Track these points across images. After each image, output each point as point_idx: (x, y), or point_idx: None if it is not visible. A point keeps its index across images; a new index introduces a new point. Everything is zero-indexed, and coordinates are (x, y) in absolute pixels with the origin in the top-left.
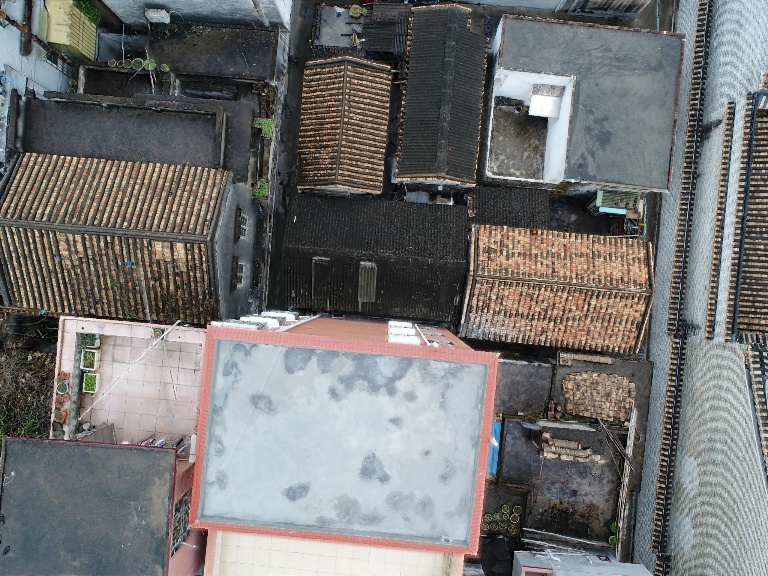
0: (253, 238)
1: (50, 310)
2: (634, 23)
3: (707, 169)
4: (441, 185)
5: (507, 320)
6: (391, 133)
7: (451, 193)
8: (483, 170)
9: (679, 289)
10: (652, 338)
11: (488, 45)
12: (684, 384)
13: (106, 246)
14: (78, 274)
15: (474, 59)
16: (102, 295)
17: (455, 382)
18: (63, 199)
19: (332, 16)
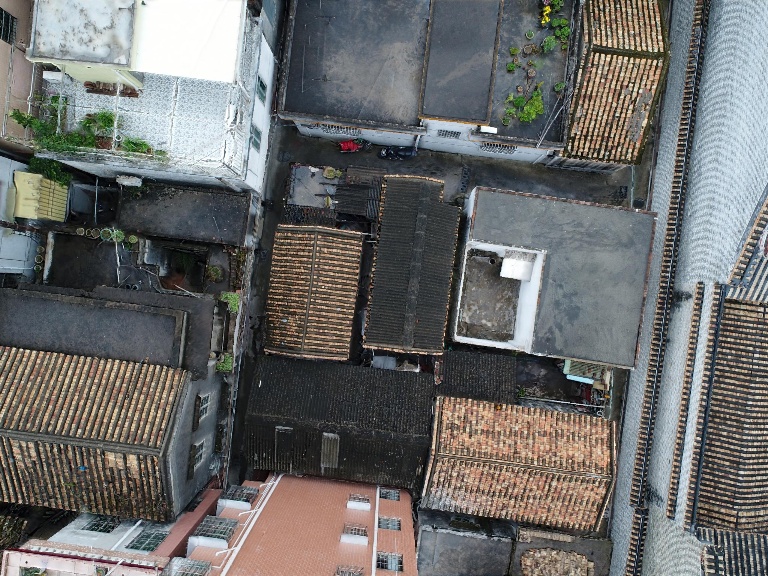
0: (217, 404)
1: (4, 501)
2: (611, 177)
3: (676, 339)
4: None
5: (468, 495)
6: (362, 289)
7: (418, 359)
8: (452, 334)
9: (643, 462)
10: (617, 499)
11: (465, 194)
12: (646, 551)
13: (59, 452)
14: (32, 473)
15: (445, 230)
16: (56, 492)
17: None
18: (19, 401)
19: (306, 176)
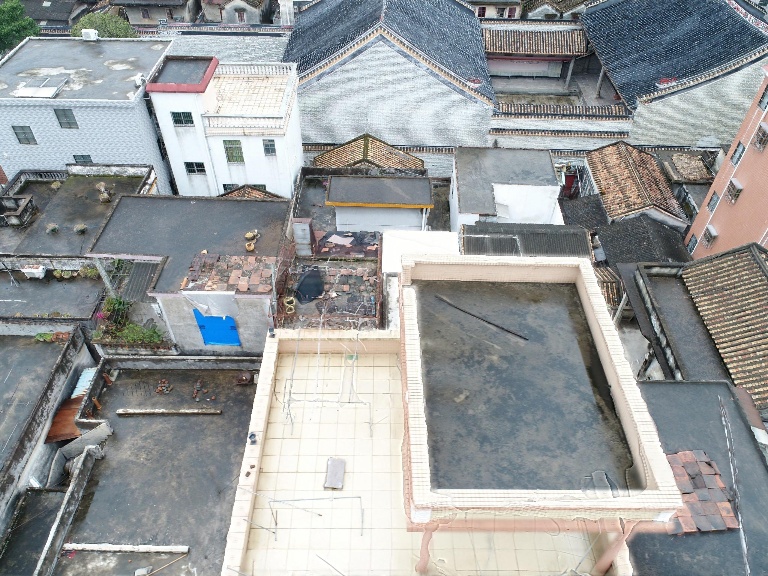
0: None
1: None
2: None
3: None
4: None
5: None
6: None
7: None
8: None
9: None
10: None
11: None
12: None
13: None
14: None
15: None
16: None
17: None
18: None
19: None
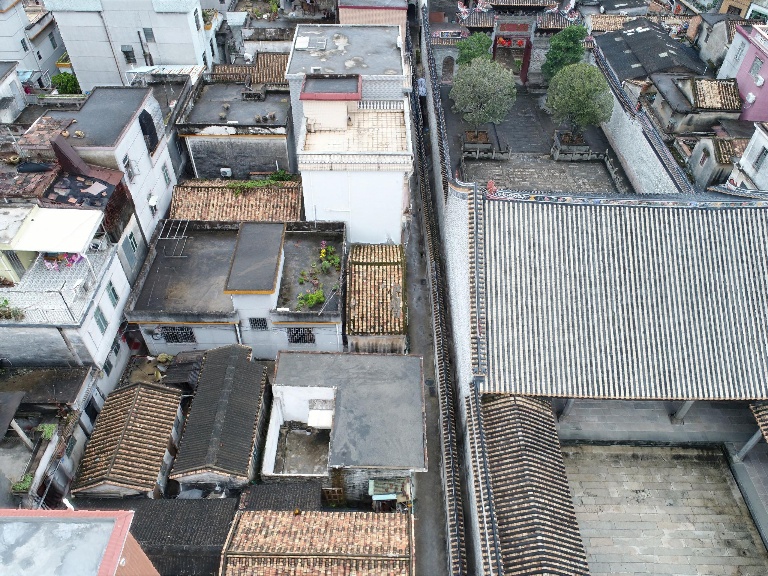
0: None
1: None
2: None
3: (469, 457)
4: (217, 484)
5: None
6: None
7: (224, 489)
8: (260, 470)
9: (458, 568)
10: None
11: None
12: None
13: None
14: None
15: (252, 380)
16: None
17: (80, 544)
18: None
19: (144, 363)
